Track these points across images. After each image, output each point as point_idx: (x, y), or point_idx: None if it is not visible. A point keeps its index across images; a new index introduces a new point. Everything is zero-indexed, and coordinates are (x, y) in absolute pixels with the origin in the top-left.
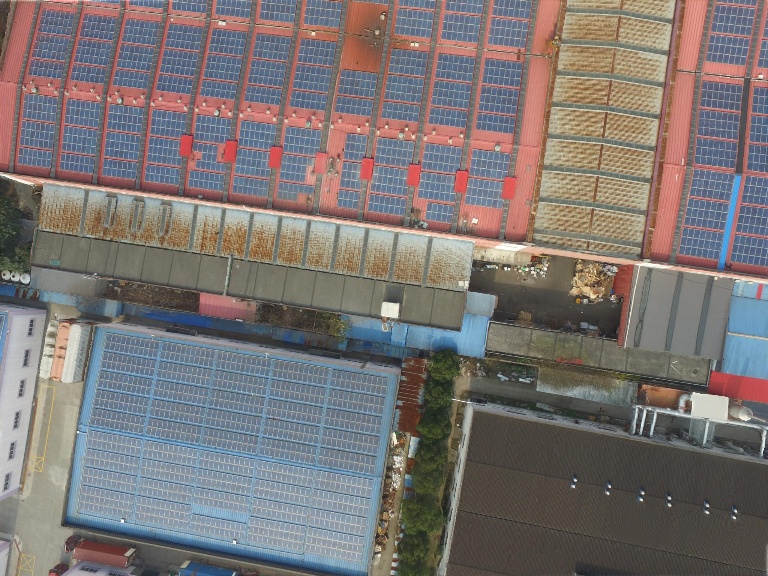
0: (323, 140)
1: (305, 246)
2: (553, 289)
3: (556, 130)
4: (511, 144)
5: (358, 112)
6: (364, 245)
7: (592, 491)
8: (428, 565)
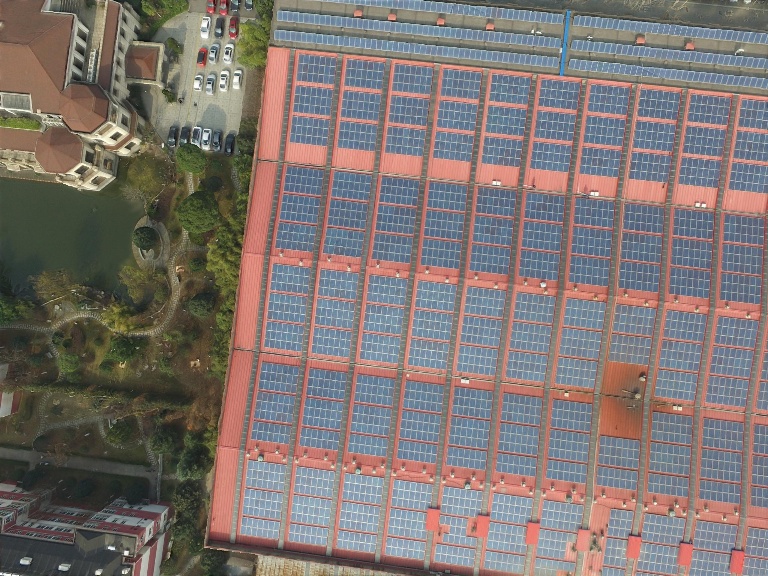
0: (585, 516)
1: None
2: None
3: None
4: None
5: (622, 485)
6: None
7: None
8: None
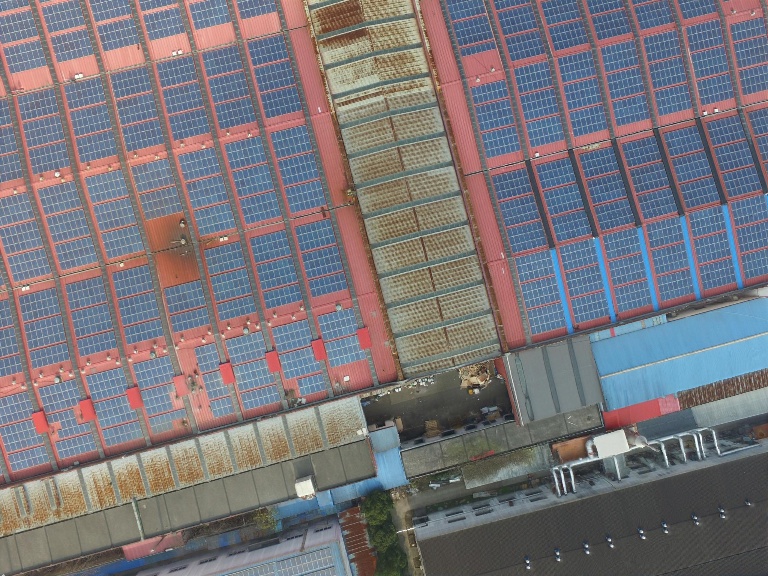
0: (174, 364)
1: (201, 460)
2: (445, 389)
3: (384, 269)
4: (349, 299)
5: (196, 324)
6: (257, 436)
7: (545, 563)
8: None
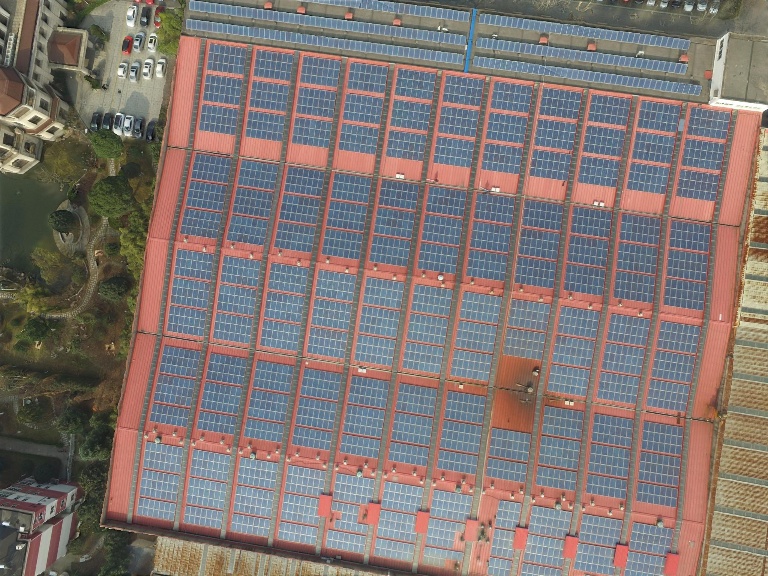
0: (474, 506)
1: None
2: None
3: (719, 502)
4: (674, 519)
5: (511, 477)
6: None
7: None
8: None
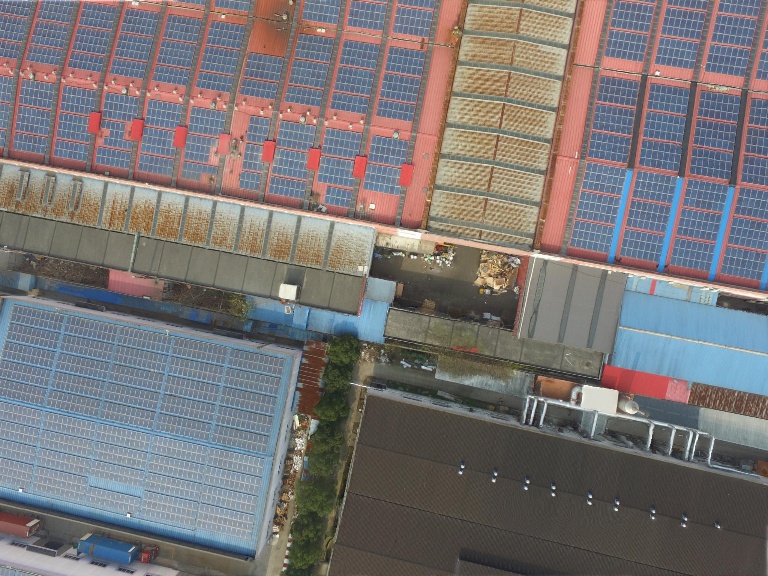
0: (227, 121)
1: (210, 226)
2: (458, 279)
3: (455, 119)
4: (410, 132)
5: (262, 95)
6: (268, 227)
7: (479, 478)
8: (317, 545)
